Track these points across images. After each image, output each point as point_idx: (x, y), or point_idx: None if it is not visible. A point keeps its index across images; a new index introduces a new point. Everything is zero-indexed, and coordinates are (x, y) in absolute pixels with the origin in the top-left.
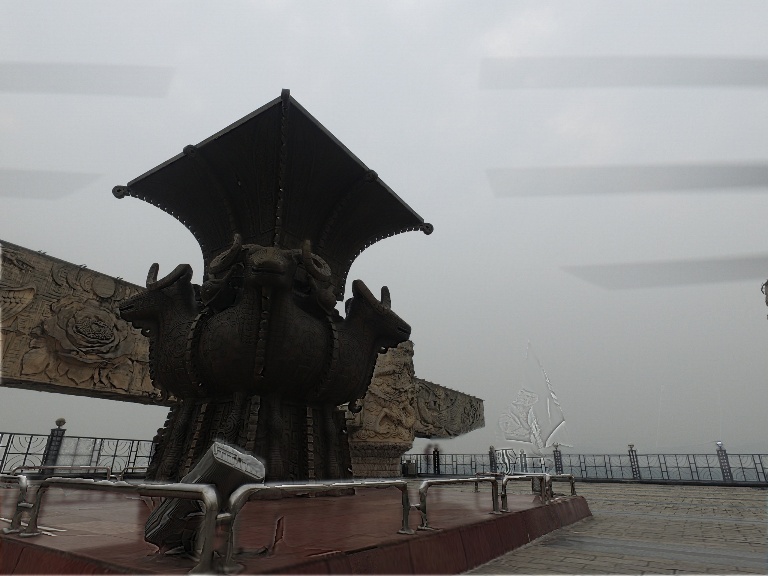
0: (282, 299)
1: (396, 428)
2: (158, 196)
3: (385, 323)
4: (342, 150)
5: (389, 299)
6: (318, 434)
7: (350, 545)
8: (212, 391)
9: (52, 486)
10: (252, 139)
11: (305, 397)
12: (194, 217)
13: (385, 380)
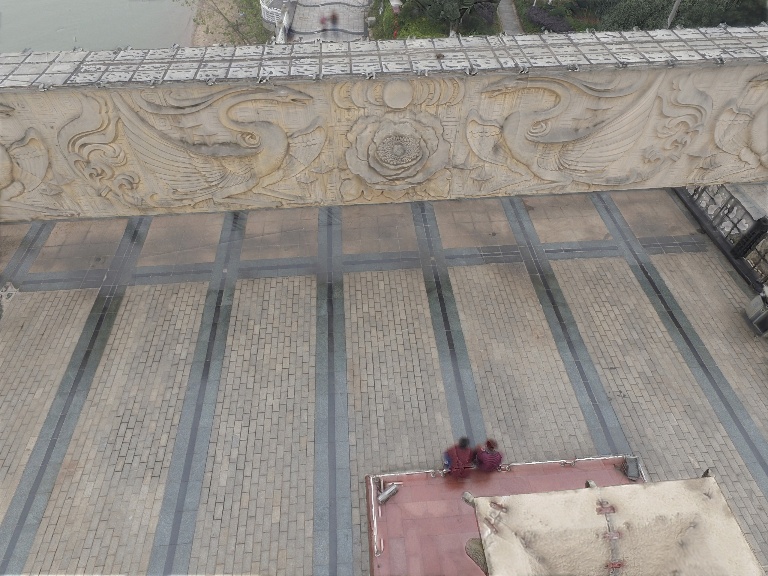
0: None
1: None
2: None
3: None
4: None
5: None
6: None
7: (594, 463)
8: None
9: None
10: None
11: None
12: None
13: None
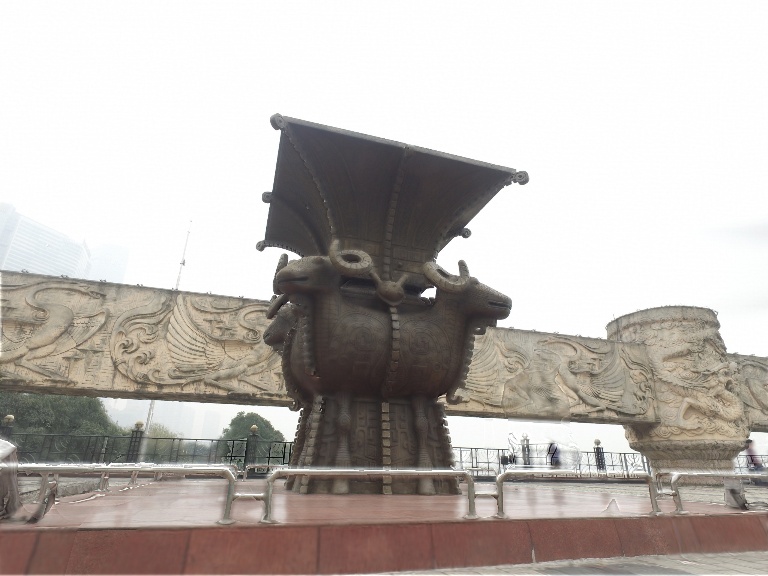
0: (322, 302)
1: (711, 422)
2: (281, 240)
3: (471, 301)
4: (365, 140)
5: (466, 273)
6: (406, 429)
7: (123, 525)
8: (307, 396)
9: None
10: (291, 167)
11: (381, 392)
12: (303, 248)
13: (679, 363)
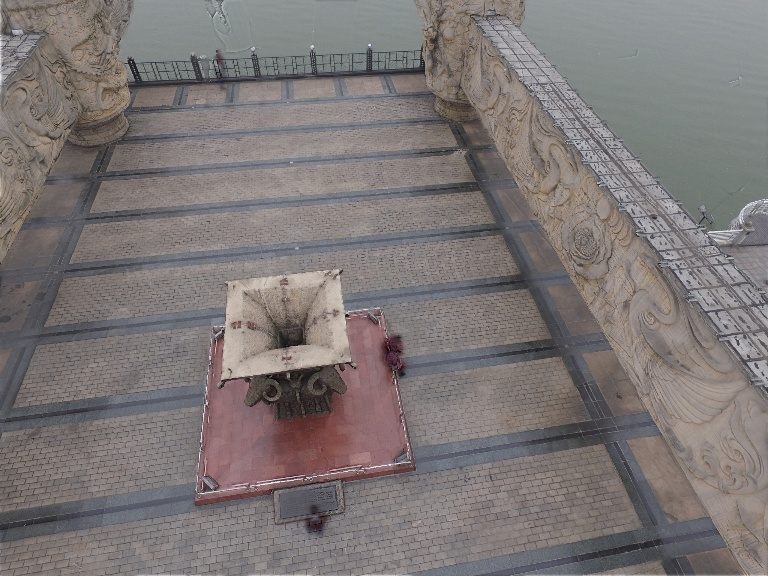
0: None
1: (118, 95)
2: None
3: None
4: None
5: None
6: None
7: None
8: None
9: None
10: None
11: None
12: None
13: (84, 50)
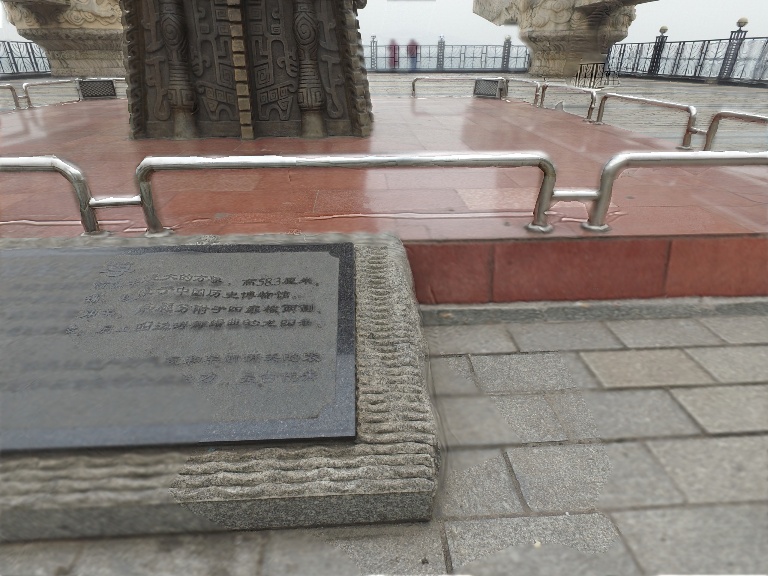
0: None
1: None
2: None
3: None
4: None
5: None
6: None
7: (765, 173)
8: None
9: (663, 166)
10: None
11: None
12: None
13: None
